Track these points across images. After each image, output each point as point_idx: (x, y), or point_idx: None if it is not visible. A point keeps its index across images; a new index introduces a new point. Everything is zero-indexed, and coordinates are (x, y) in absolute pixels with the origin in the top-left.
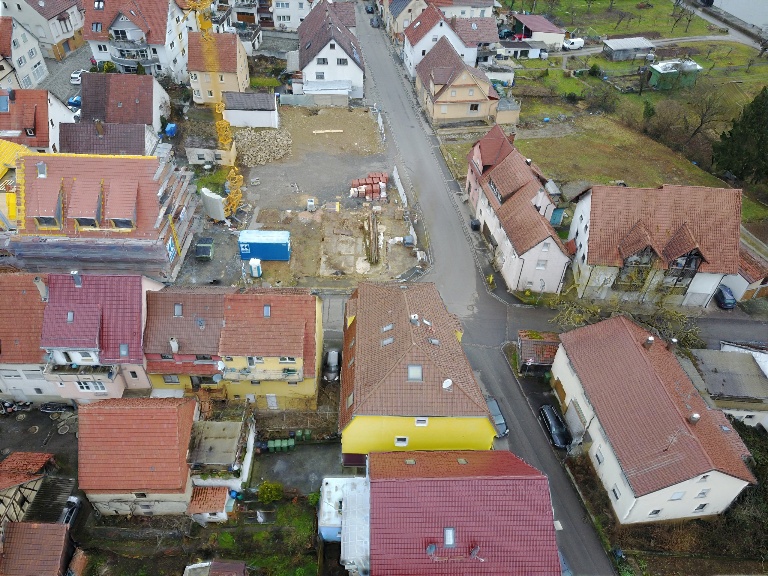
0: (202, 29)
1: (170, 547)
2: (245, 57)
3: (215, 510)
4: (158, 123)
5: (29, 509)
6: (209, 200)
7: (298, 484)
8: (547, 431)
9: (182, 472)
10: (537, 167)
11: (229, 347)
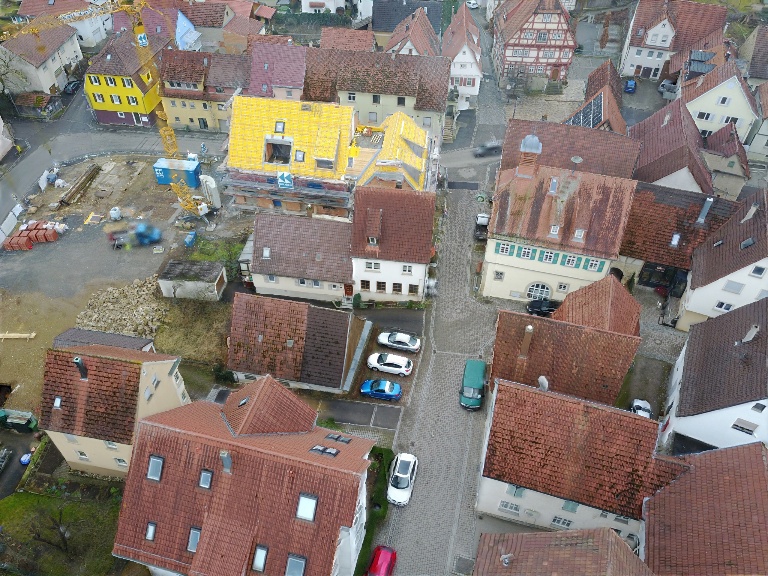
0: None
1: None
2: None
3: None
4: None
5: None
6: None
7: None
8: None
9: None
10: None
11: None
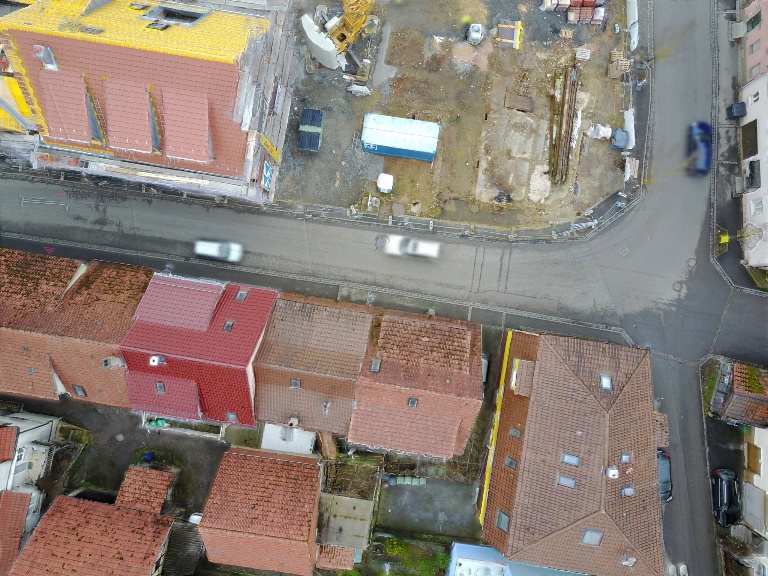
0: None
1: None
2: None
3: (345, 568)
4: None
5: (166, 557)
6: (314, 46)
7: (427, 522)
8: (716, 502)
9: (313, 559)
10: None
11: (361, 434)
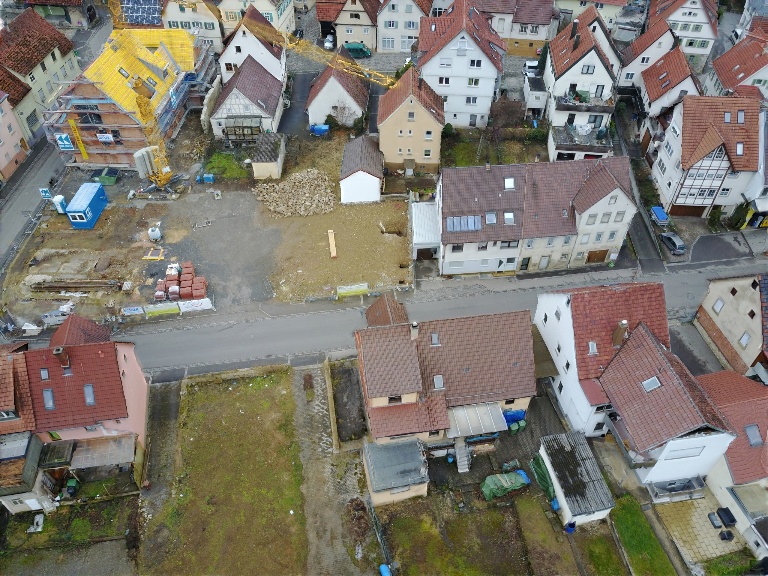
0: None
1: None
2: (435, 131)
3: None
4: (322, 118)
5: None
6: None
7: None
8: None
9: None
10: (5, 402)
11: None
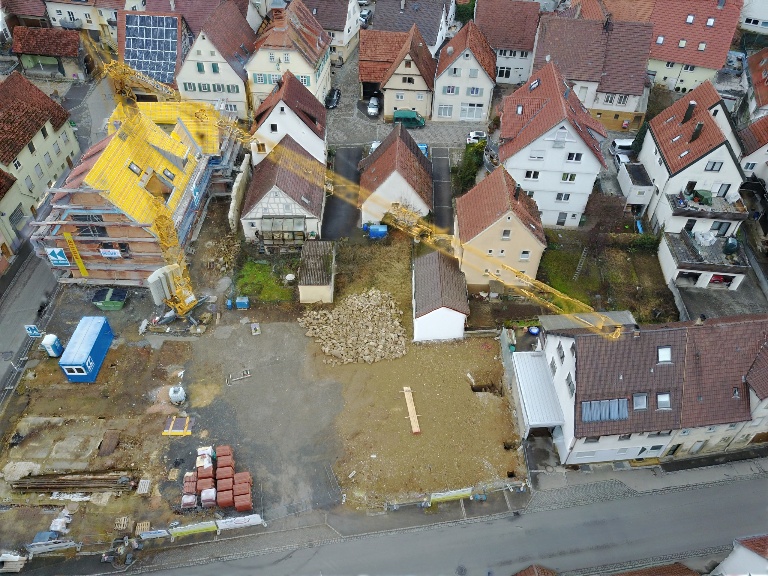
0: None
1: None
2: (534, 251)
3: None
4: (379, 215)
5: None
6: None
7: None
8: None
9: None
10: None
11: None
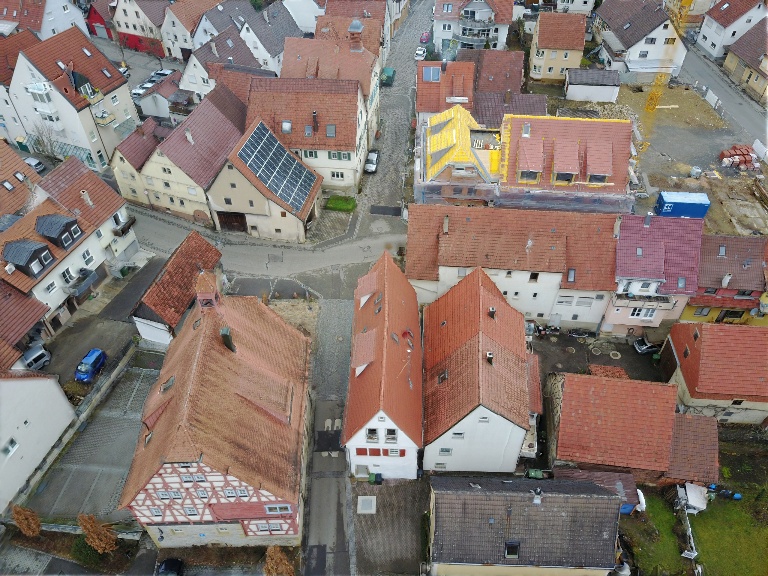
0: (682, 6)
1: (758, 448)
2: None
3: None
4: None
5: None
6: None
7: None
8: None
9: None
10: None
11: None
